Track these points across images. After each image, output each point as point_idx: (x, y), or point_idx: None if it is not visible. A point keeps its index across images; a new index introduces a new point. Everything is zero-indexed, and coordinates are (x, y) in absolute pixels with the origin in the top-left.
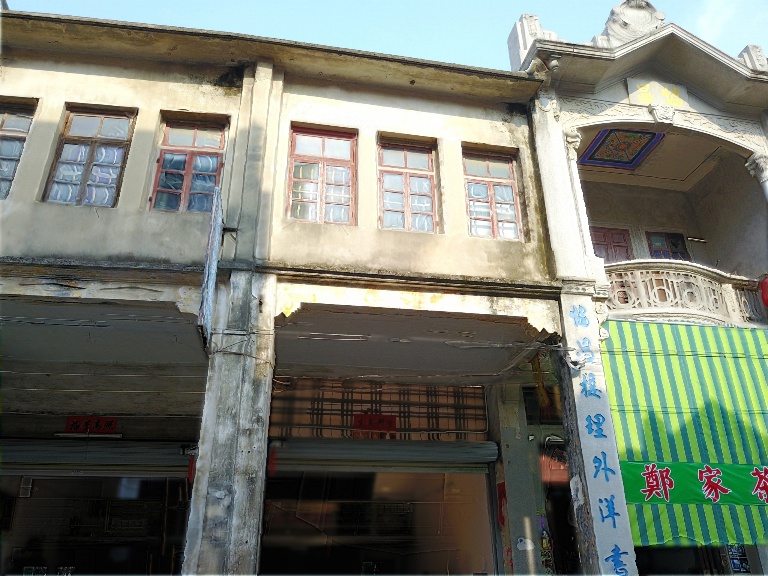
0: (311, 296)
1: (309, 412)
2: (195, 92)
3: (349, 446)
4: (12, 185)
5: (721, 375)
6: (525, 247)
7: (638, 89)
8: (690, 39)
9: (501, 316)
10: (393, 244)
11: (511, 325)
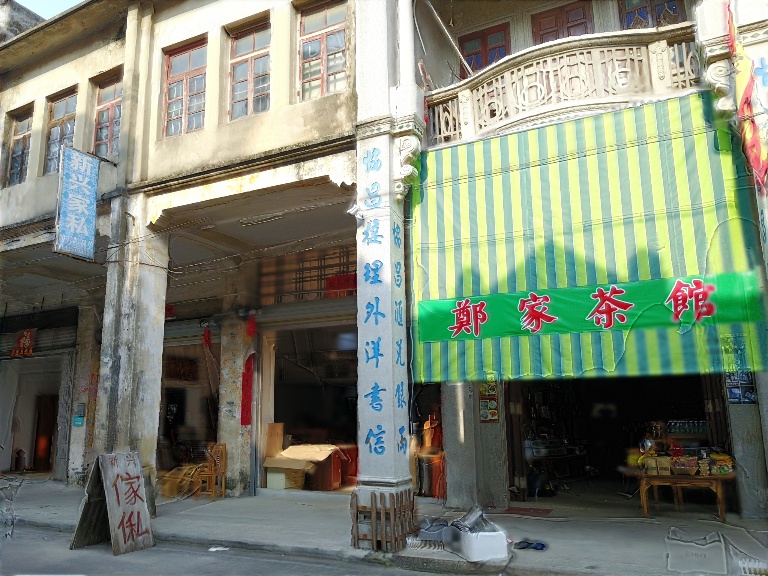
0: (168, 203)
1: (294, 281)
2: (106, 53)
3: (310, 307)
4: (27, 170)
5: (573, 181)
6: (339, 98)
7: None
8: None
9: (308, 180)
10: (228, 136)
11: (332, 184)
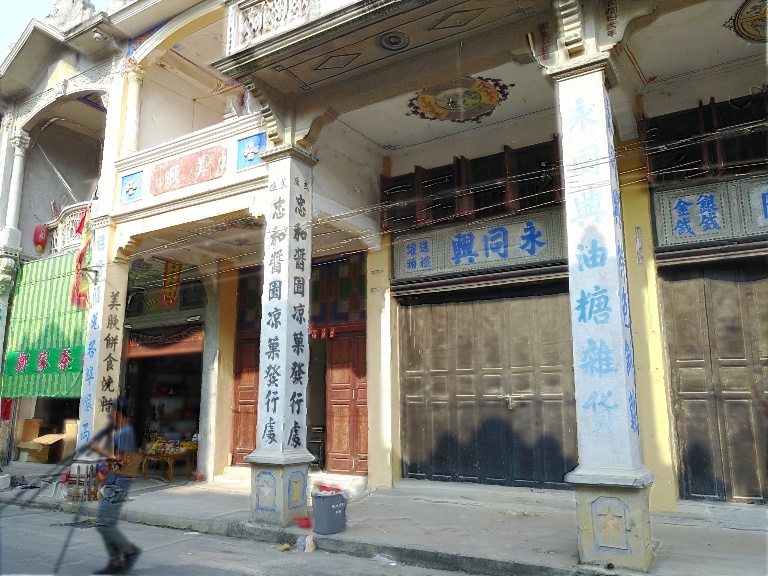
0: None
1: None
2: None
3: None
4: None
5: (65, 289)
6: None
7: (52, 73)
8: (41, 25)
9: None
10: None
11: None
